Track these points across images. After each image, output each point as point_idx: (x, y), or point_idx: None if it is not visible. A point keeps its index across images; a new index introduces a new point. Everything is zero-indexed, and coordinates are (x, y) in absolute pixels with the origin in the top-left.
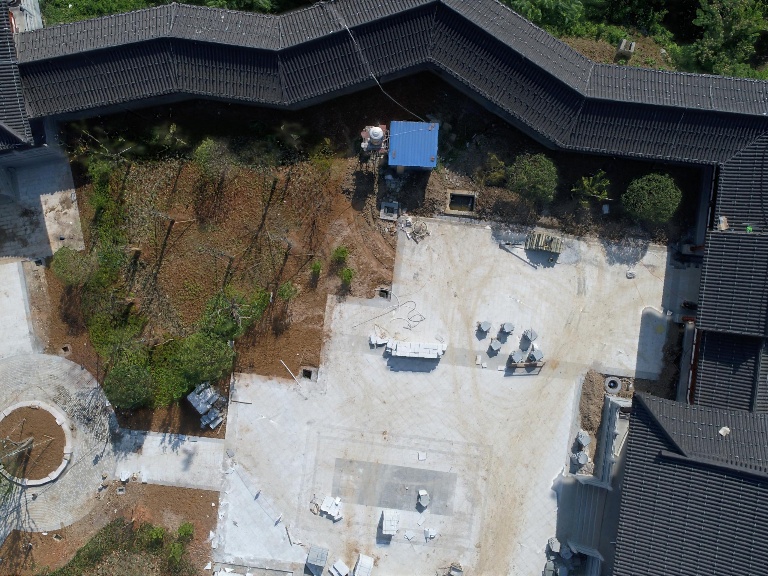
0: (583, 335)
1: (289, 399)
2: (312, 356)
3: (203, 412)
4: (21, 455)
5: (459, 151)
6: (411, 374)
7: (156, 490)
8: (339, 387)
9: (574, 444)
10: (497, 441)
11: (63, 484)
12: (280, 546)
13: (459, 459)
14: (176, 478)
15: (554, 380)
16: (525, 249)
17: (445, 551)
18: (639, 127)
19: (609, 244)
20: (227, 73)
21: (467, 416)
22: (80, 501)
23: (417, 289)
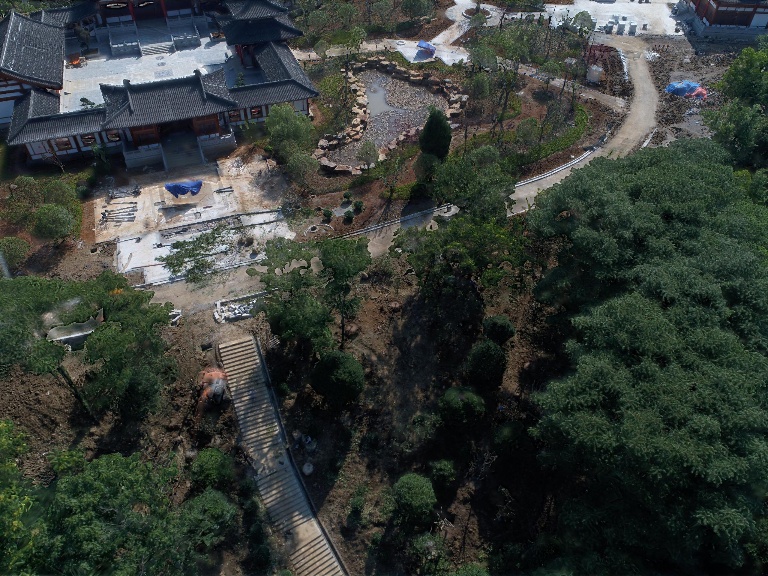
0: None
1: None
2: None
3: None
4: (475, 13)
5: None
6: None
7: None
8: None
9: None
10: None
11: None
12: None
13: None
14: None
15: None
16: None
17: None
18: None
19: None
20: None
21: None
22: None
23: None
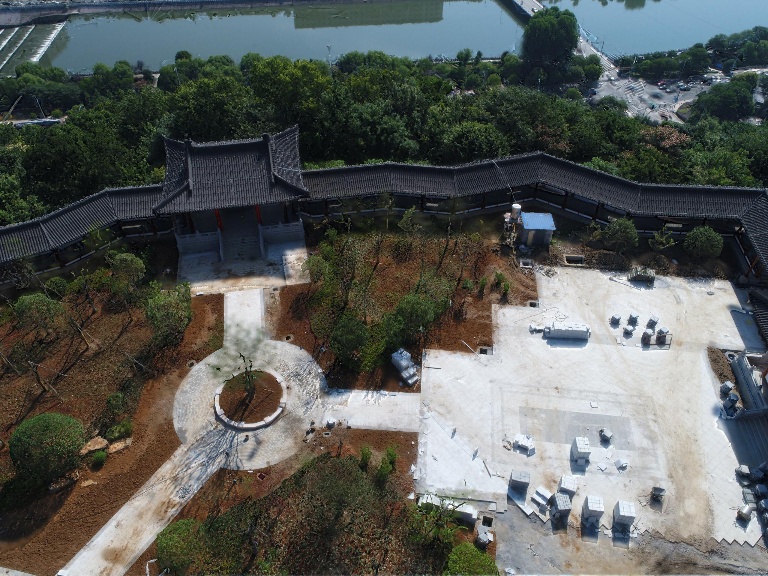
0: (693, 326)
1: (472, 366)
2: (486, 339)
3: (405, 364)
4: (242, 403)
5: (565, 237)
6: (568, 349)
7: (360, 433)
8: (512, 358)
9: (721, 395)
10: (654, 393)
11: (274, 430)
12: (480, 478)
13: (627, 407)
14: (378, 423)
15: (683, 353)
16: (628, 280)
17: (640, 481)
18: (679, 201)
19: (686, 278)
20: (422, 182)
21: (622, 376)
22: (288, 443)
23: (557, 301)
